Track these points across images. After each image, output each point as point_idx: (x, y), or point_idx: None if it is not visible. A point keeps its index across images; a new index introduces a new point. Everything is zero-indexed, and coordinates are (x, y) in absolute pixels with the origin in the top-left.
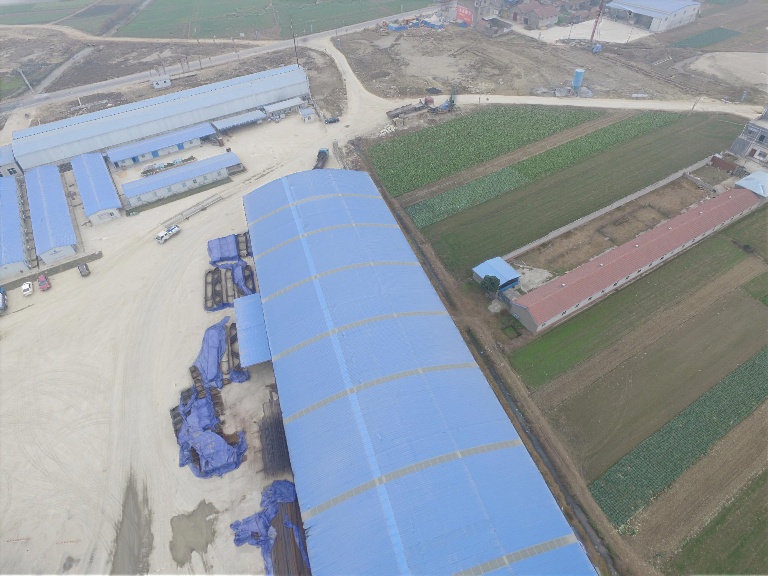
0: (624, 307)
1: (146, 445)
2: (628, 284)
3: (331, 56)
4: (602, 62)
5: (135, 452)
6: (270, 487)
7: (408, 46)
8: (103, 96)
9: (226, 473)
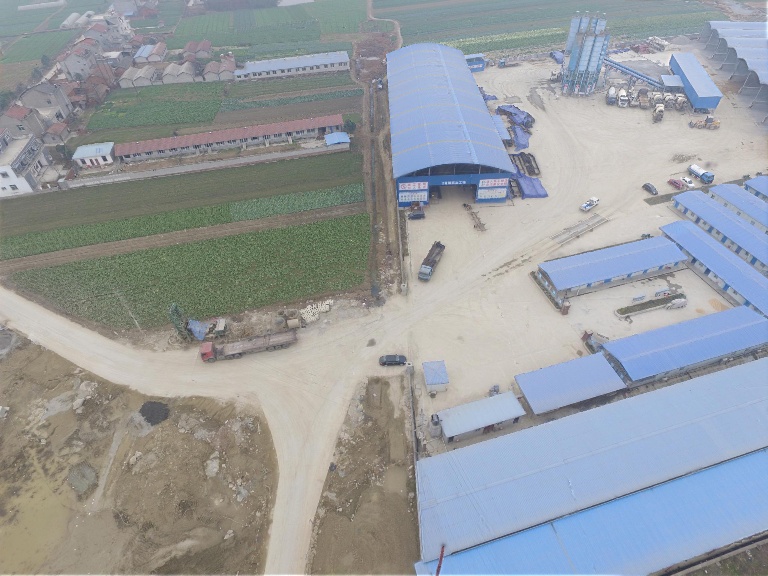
0: None
1: None
2: None
3: None
4: None
5: None
6: None
7: None
8: None
9: None
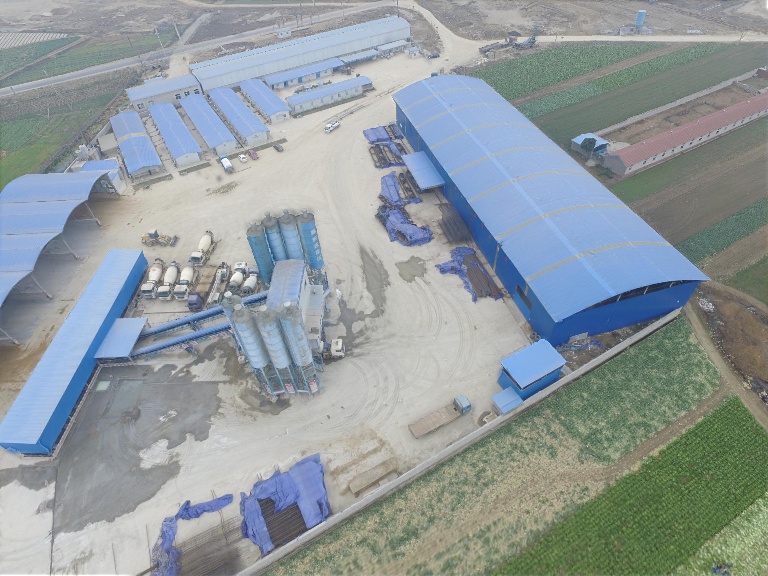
0: (689, 162)
1: (364, 232)
2: (691, 150)
3: (419, 12)
4: (658, 9)
5: (358, 236)
6: (455, 249)
7: (483, 3)
8: (240, 44)
9: (423, 244)
